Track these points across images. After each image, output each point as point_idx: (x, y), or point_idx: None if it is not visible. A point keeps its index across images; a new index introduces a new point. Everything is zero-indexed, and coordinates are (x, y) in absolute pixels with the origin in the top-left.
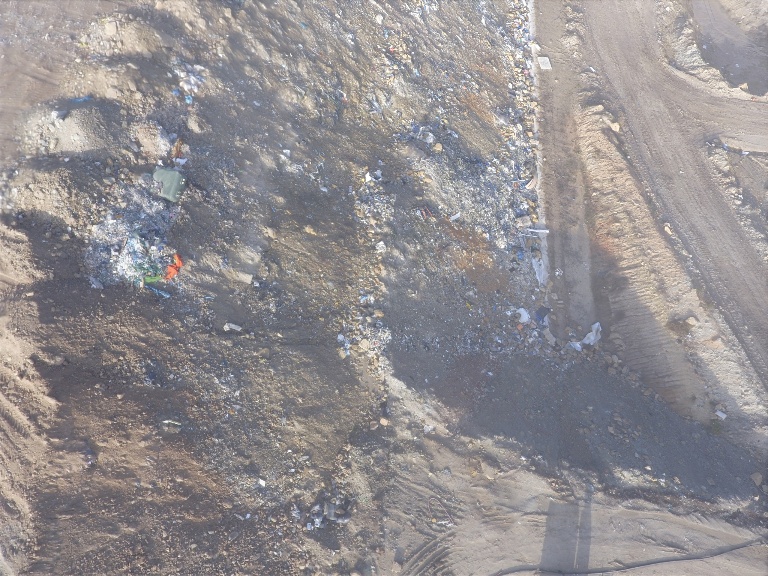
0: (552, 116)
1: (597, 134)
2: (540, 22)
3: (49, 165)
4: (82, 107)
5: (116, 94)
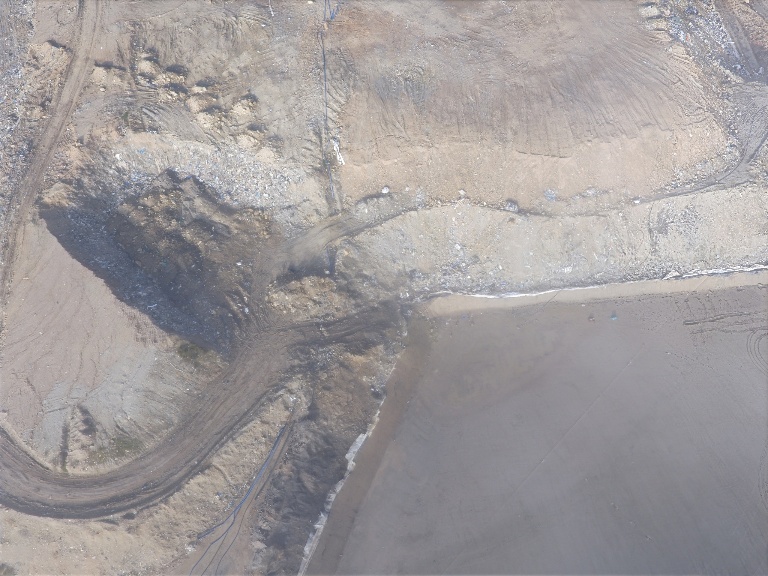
0: (719, 2)
1: (741, 5)
2: None
3: (655, 18)
4: (653, 4)
5: (655, 1)
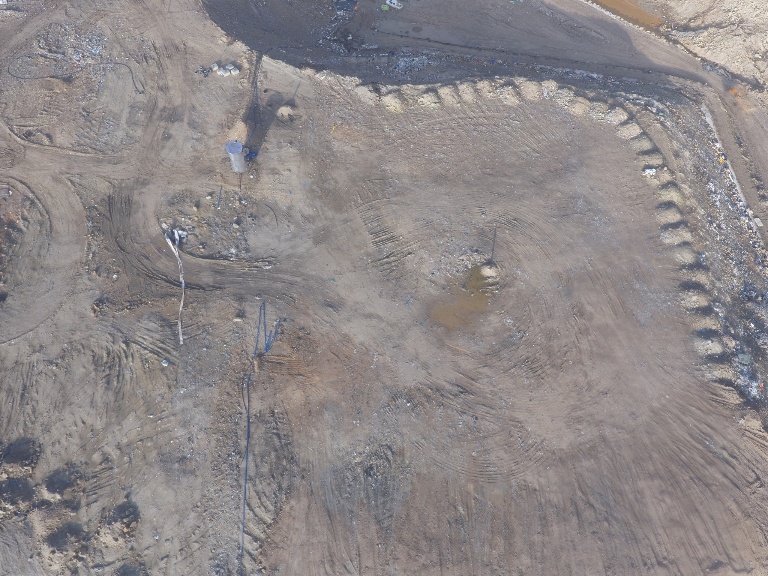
0: None
1: None
2: (745, 193)
3: (718, 361)
4: (713, 336)
5: (715, 327)
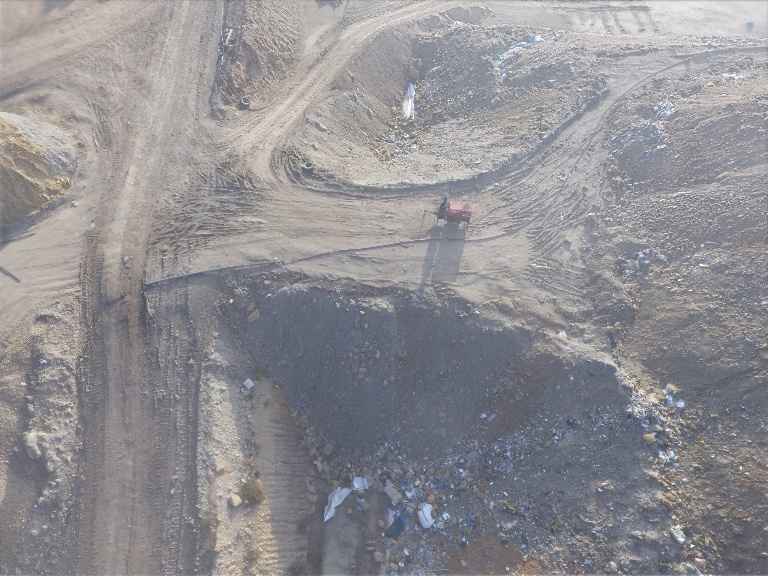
0: None
1: None
2: None
3: None
4: None
5: None
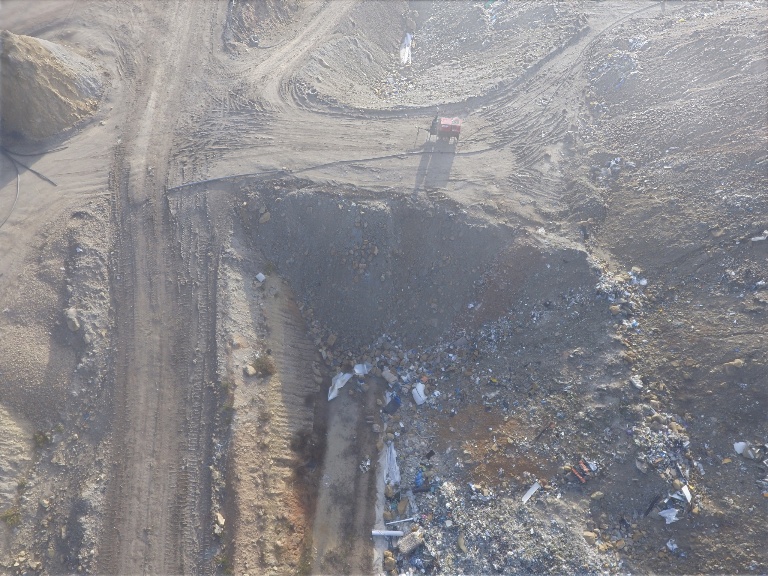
0: None
1: None
2: None
3: None
4: None
5: None
